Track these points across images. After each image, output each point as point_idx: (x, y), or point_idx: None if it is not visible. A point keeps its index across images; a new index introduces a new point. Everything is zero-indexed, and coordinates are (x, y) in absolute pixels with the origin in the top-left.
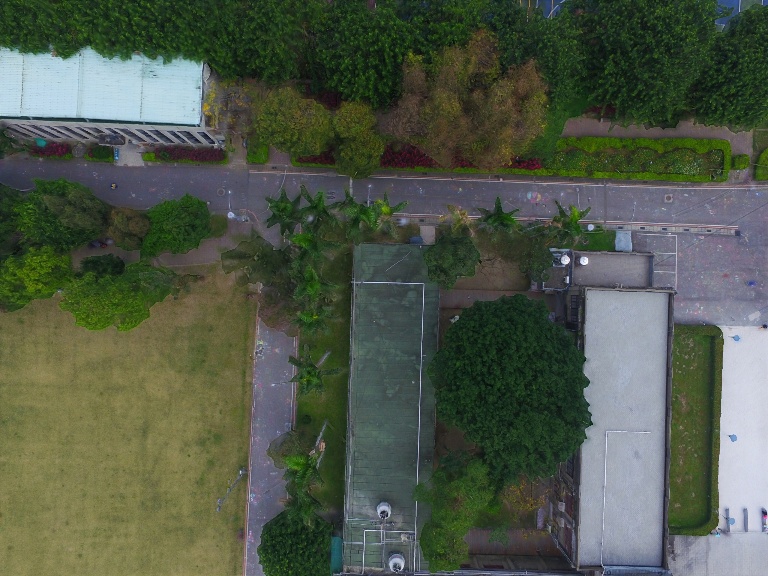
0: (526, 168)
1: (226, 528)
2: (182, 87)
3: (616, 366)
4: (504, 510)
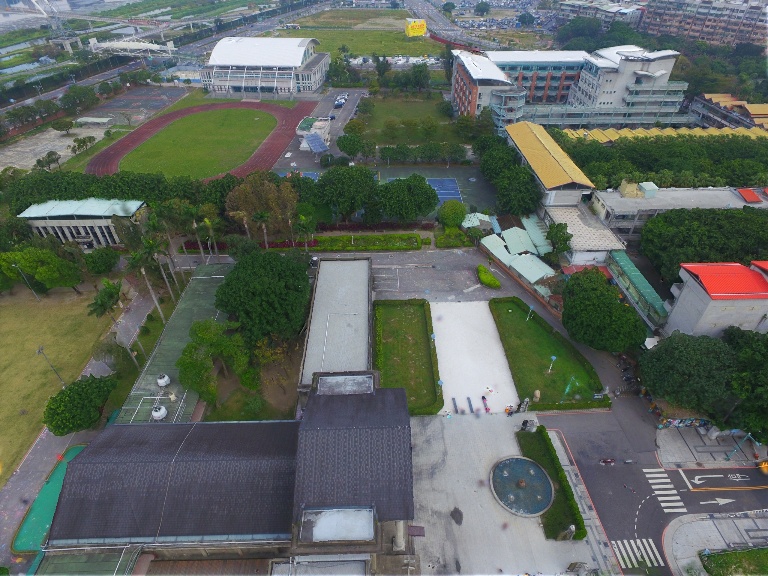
0: (308, 247)
1: (27, 428)
2: (129, 207)
3: (337, 288)
4: (269, 408)
